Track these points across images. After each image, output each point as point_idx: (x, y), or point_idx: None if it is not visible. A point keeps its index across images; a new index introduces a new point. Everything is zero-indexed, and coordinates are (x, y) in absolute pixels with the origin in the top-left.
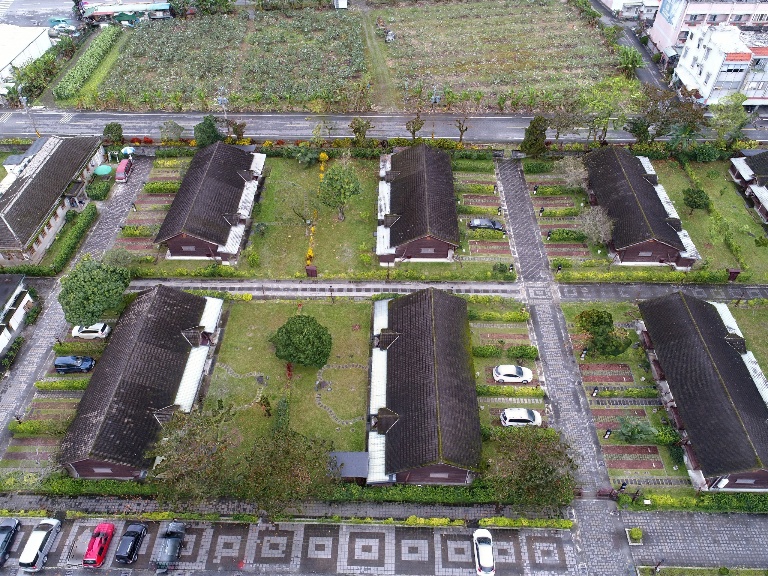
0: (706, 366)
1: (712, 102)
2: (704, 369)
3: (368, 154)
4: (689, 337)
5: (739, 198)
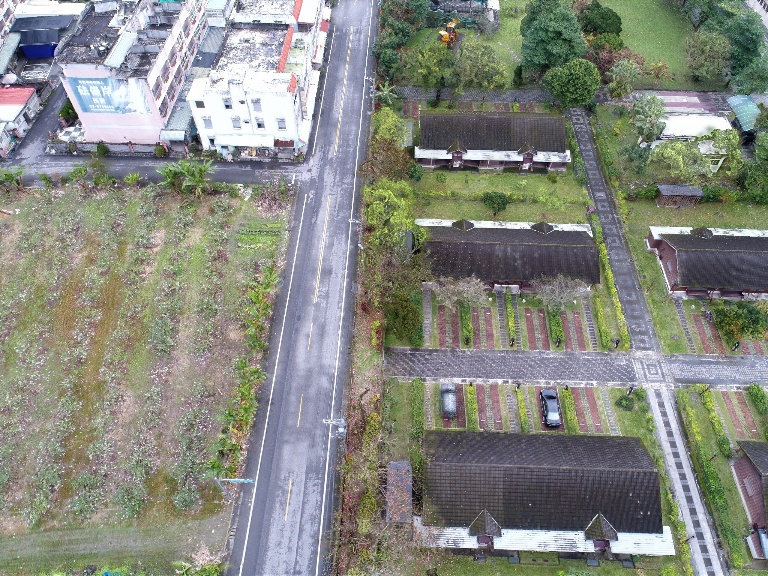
0: (764, 258)
1: (306, 137)
2: (767, 260)
3: (391, 573)
4: (732, 259)
5: (463, 173)
